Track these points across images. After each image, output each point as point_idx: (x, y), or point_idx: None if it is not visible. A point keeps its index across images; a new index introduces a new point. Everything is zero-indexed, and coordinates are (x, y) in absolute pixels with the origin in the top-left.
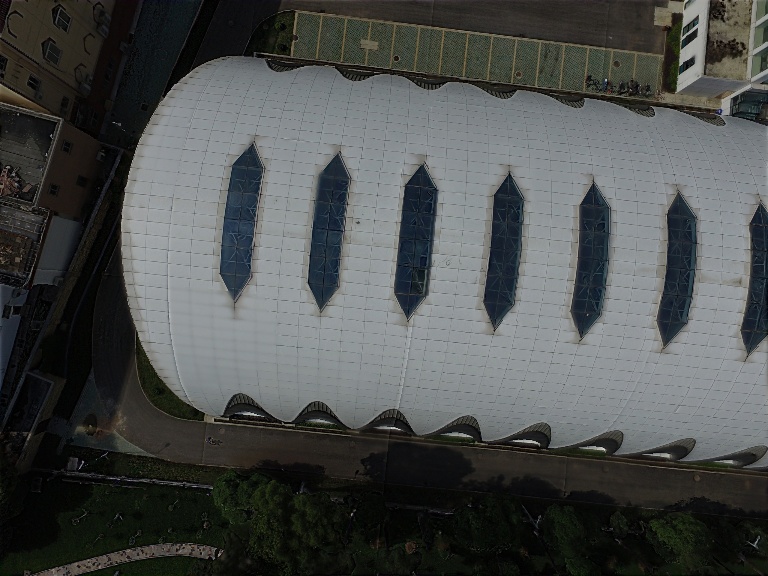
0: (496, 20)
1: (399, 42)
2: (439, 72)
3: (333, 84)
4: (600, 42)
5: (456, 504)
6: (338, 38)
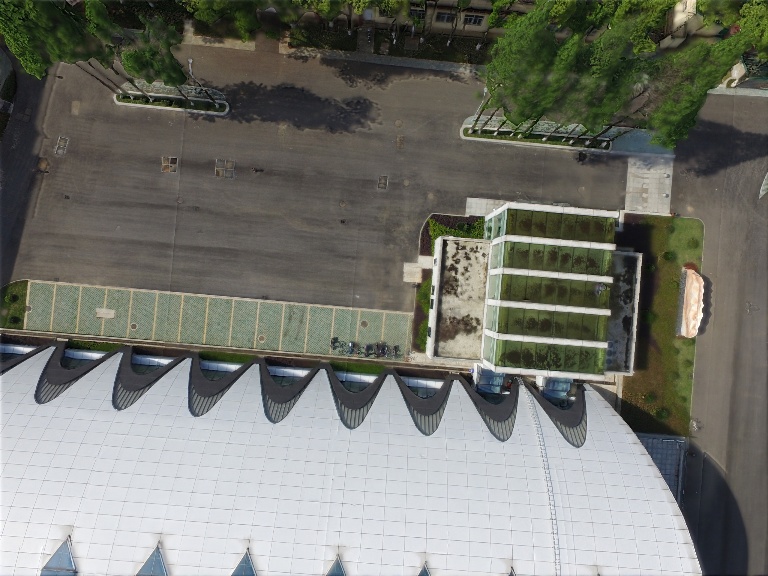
0: (237, 282)
1: (136, 309)
2: (178, 339)
3: (11, 416)
4: (347, 301)
5: None
6: (73, 307)
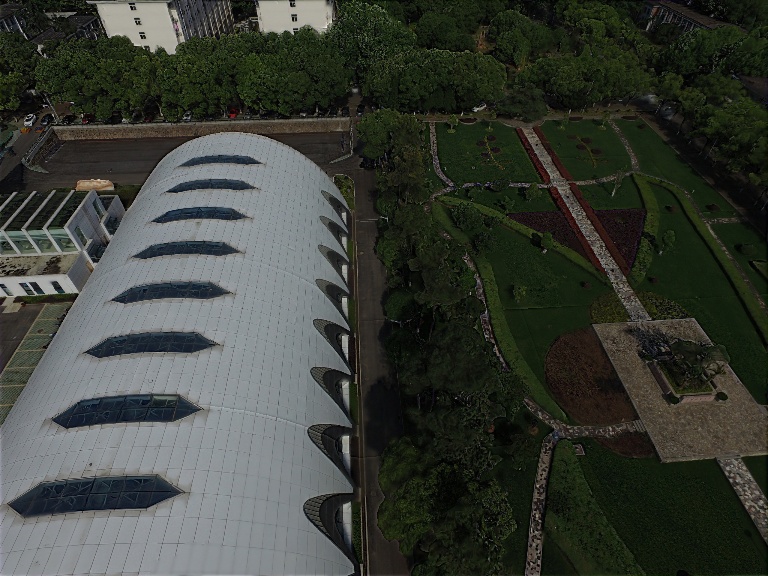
0: None
1: None
2: None
3: None
4: (15, 344)
5: None
6: None
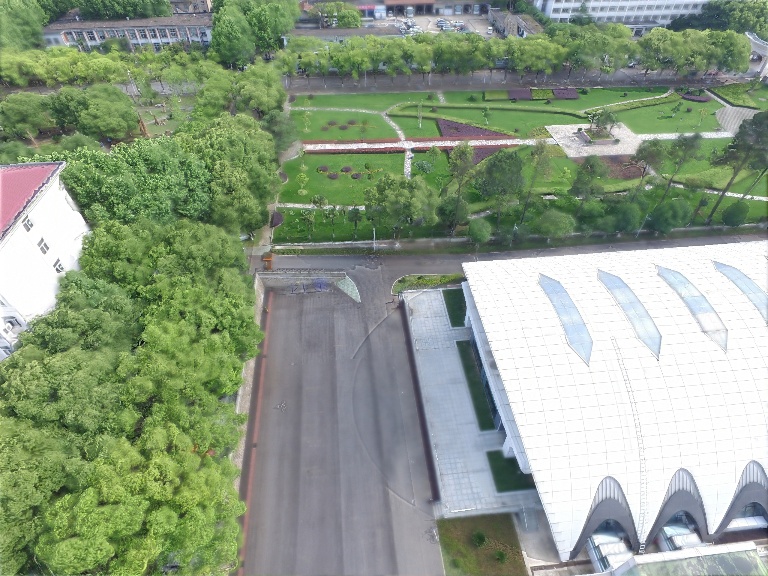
0: None
1: None
2: None
3: None
4: None
5: (672, 234)
6: None
